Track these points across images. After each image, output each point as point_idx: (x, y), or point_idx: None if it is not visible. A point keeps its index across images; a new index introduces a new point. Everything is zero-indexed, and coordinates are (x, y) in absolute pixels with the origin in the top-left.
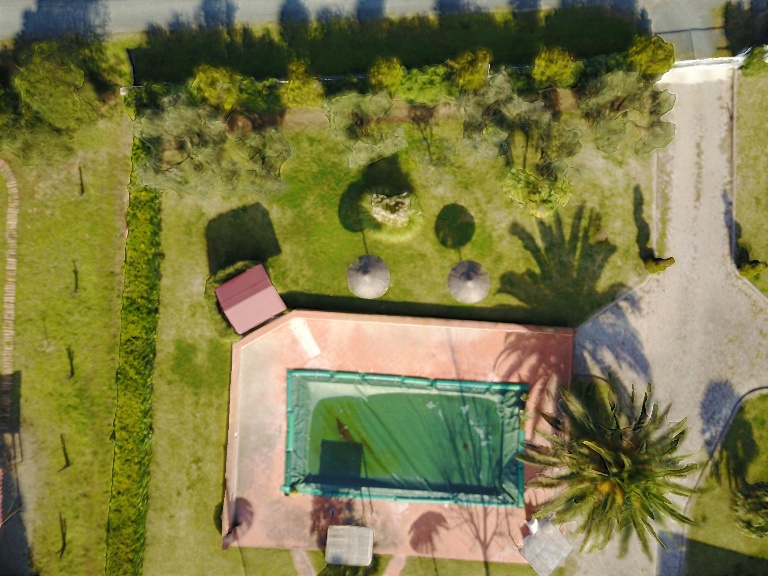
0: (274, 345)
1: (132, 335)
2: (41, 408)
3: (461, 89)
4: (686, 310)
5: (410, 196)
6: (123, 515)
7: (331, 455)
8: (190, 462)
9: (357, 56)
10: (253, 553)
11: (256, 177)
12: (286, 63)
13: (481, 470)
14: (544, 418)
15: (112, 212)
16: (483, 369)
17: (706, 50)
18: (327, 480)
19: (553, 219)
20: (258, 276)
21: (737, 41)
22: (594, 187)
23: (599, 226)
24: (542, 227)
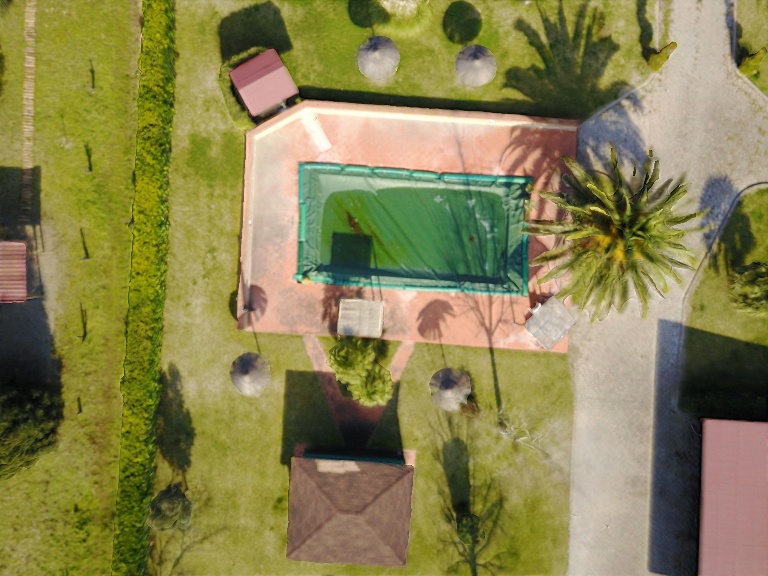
0: (286, 139)
1: (149, 122)
2: (61, 203)
3: None
4: (687, 109)
5: None
6: (142, 294)
7: (342, 247)
8: (206, 252)
9: None
10: (267, 339)
11: None
12: None
13: (487, 261)
14: None
15: (127, 16)
16: (489, 163)
17: None
18: (338, 270)
19: (558, 17)
20: (271, 58)
21: None
22: None
23: (603, 24)
24: (547, 24)
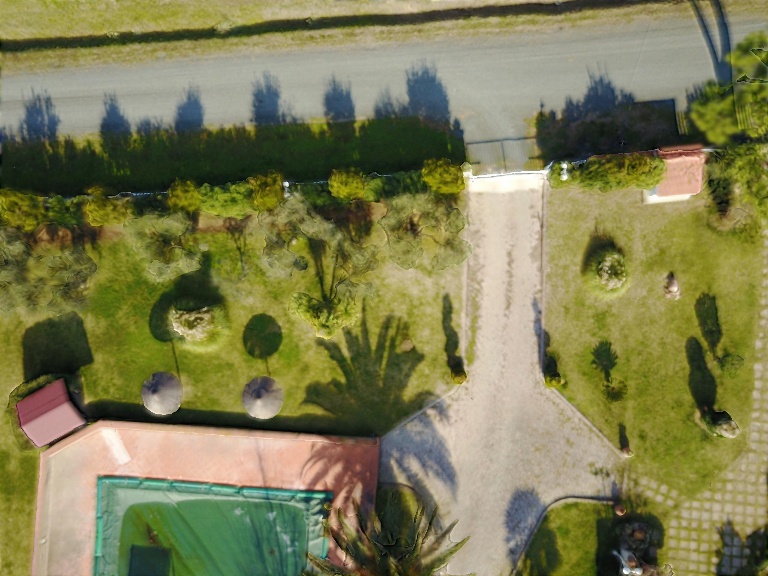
0: (86, 451)
1: None
2: None
3: (258, 208)
4: (494, 418)
5: (214, 309)
6: None
7: (141, 560)
8: (2, 565)
9: (175, 166)
10: None
11: (53, 296)
12: (106, 173)
13: None
14: (332, 534)
15: None
16: (290, 476)
17: (517, 160)
18: None
19: (360, 329)
20: (56, 391)
21: (548, 151)
22: (403, 296)
23: (406, 335)
24: (348, 337)
